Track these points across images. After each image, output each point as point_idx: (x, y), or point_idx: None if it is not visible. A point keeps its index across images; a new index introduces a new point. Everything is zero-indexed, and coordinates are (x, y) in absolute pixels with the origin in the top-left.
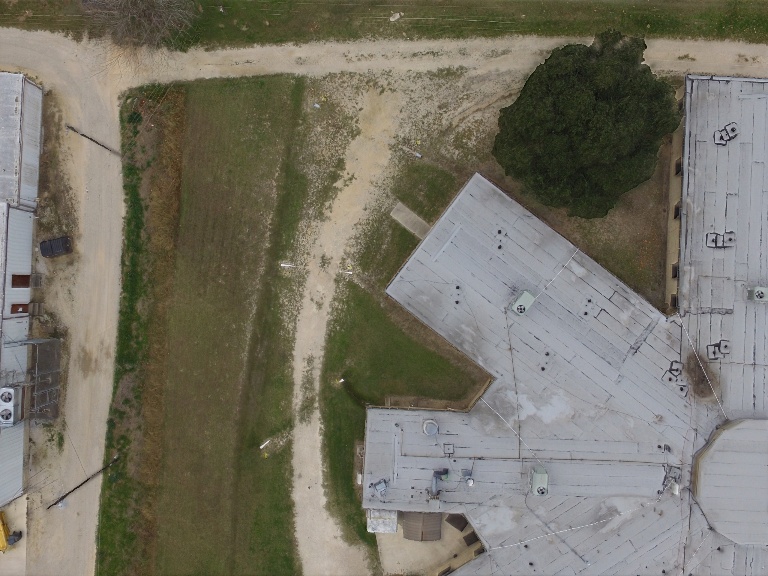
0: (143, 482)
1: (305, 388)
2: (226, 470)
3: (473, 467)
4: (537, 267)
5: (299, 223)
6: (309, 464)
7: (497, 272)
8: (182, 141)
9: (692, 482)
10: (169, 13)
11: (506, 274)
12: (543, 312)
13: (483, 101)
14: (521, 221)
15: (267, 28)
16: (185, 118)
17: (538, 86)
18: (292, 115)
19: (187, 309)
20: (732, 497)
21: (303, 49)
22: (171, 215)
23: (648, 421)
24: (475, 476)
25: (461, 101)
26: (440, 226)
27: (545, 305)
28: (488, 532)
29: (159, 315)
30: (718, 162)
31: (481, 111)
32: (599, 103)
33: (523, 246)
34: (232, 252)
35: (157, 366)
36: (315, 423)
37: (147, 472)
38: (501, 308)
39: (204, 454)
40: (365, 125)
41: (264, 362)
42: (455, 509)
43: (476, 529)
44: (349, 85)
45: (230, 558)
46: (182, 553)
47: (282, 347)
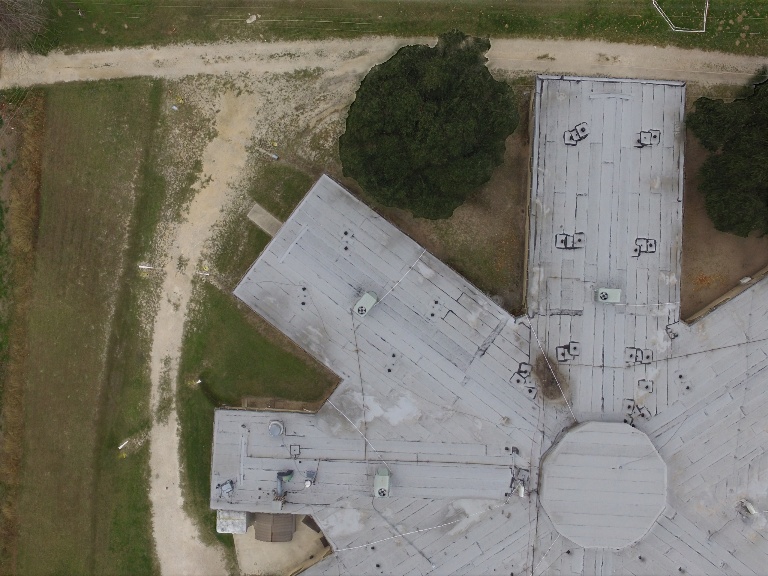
0: (3, 482)
1: (162, 389)
2: (85, 470)
3: (318, 468)
4: (384, 268)
5: (157, 225)
6: (166, 465)
7: (343, 273)
8: (41, 144)
9: (539, 485)
10: (17, 17)
11: (352, 275)
12: (389, 313)
13: (340, 102)
14: (368, 222)
15: (126, 31)
16: (44, 121)
17: (369, 87)
18: (150, 117)
19: (46, 310)
20: (576, 500)
21: (161, 52)
22: (29, 217)
23: (496, 423)
24: (321, 477)
25: (318, 102)
26: (287, 228)
27: (391, 306)
28: (335, 534)
29: (18, 316)
30: (568, 162)
31: (338, 112)
32: (427, 104)
33: (370, 247)
34: (91, 254)
35: (17, 367)
36: (172, 424)
37: (6, 472)
38: (347, 309)
39: (64, 454)
40: (222, 127)
41: (123, 363)
42: (302, 510)
43: (323, 530)
44: (206, 87)
45: (90, 557)
46: (43, 552)
47: (140, 348)
